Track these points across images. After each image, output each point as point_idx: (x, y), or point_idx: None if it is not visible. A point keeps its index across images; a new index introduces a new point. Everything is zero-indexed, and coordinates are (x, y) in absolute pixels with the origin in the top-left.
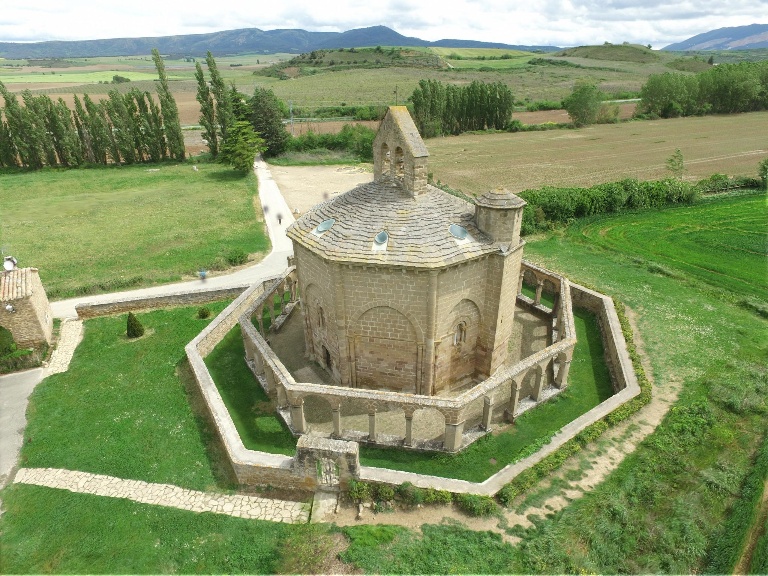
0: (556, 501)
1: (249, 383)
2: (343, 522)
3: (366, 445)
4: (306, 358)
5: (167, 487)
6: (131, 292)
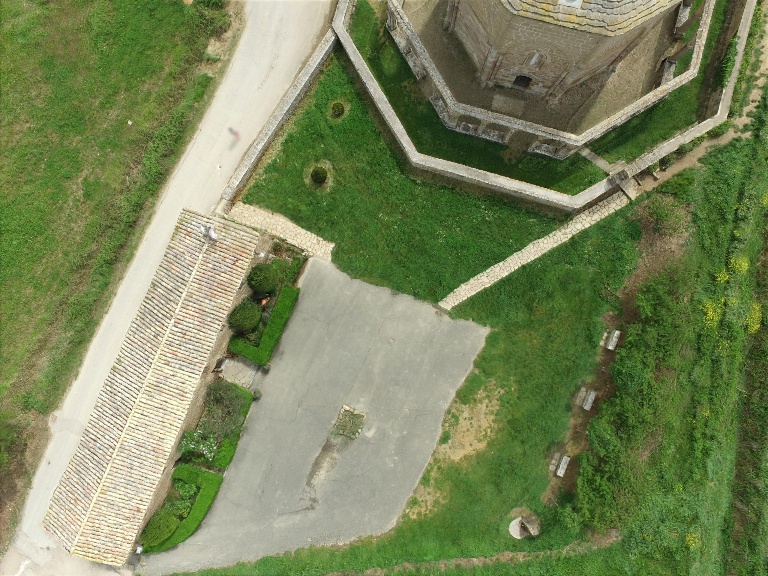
0: (755, 94)
1: (476, 145)
2: (649, 187)
3: (610, 131)
4: (485, 87)
5: (533, 244)
6: (200, 136)
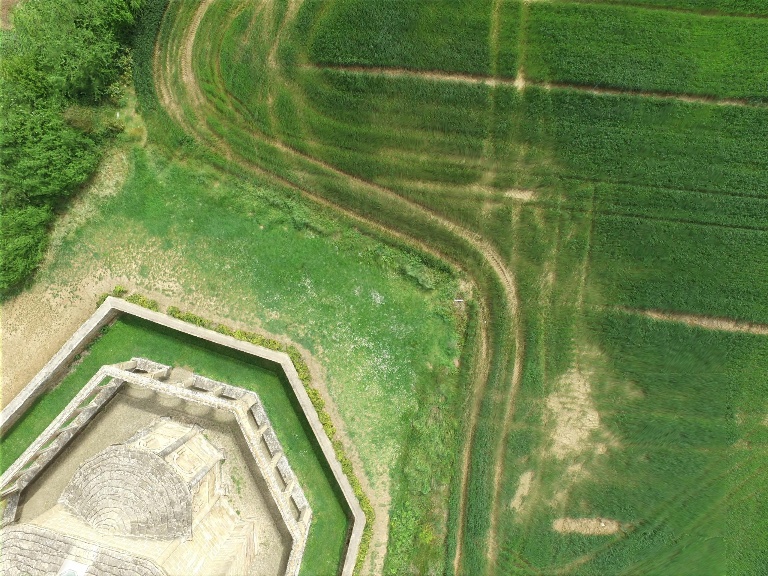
0: None
1: None
2: None
3: None
4: None
5: None
6: None
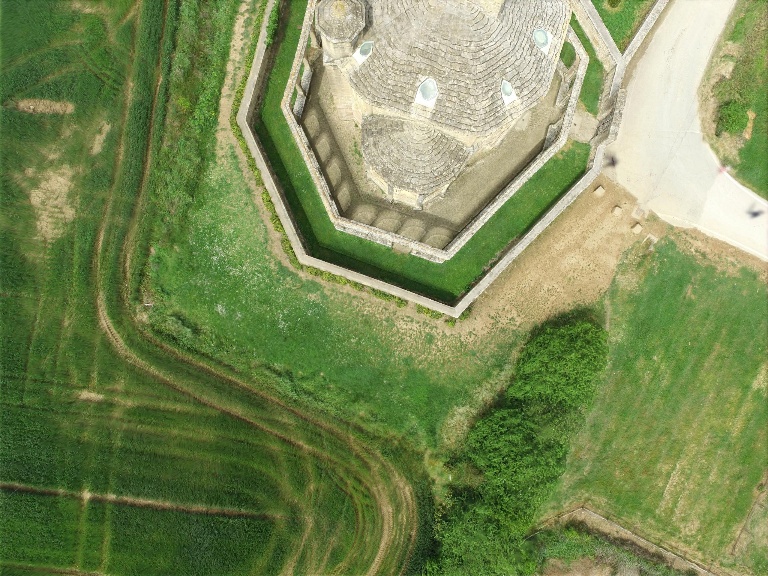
0: None
1: None
2: None
3: None
4: None
5: None
6: None
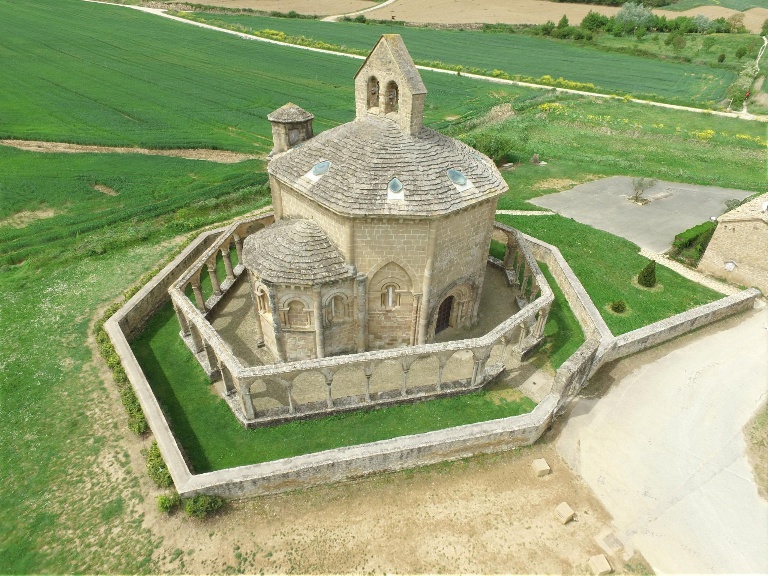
0: None
1: None
2: None
3: None
4: None
5: None
6: None
